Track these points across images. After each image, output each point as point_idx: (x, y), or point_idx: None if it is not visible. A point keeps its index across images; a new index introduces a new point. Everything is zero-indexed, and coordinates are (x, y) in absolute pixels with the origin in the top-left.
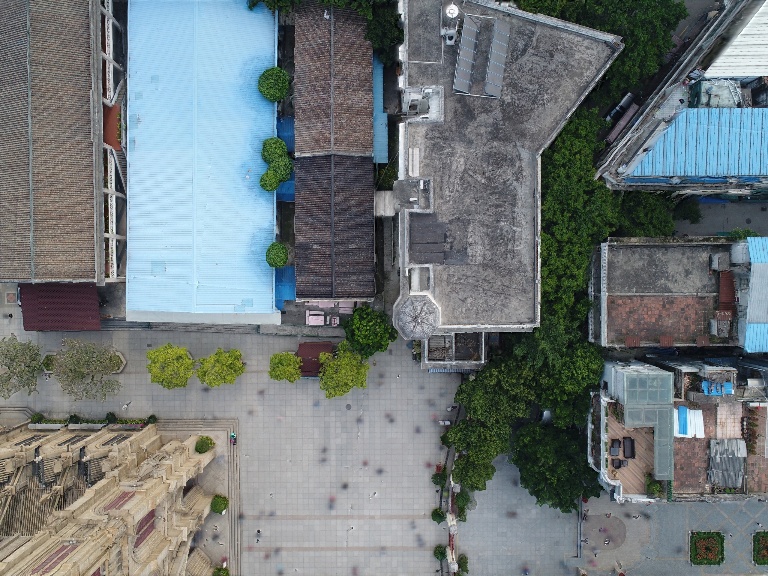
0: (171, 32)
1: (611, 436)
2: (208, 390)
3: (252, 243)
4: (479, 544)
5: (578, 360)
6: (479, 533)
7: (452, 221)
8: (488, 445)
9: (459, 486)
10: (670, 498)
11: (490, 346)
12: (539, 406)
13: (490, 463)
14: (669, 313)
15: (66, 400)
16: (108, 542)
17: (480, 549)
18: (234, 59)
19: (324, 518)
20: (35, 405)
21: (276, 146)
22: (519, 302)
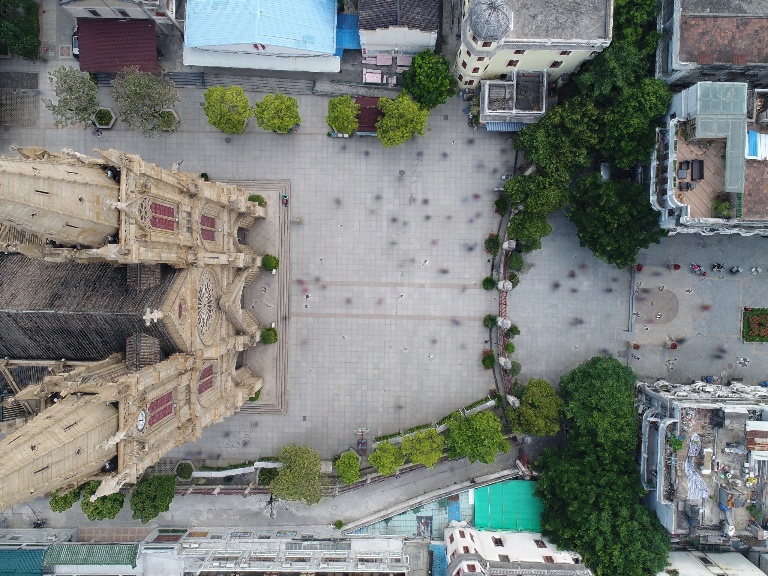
0: None
1: (679, 159)
2: (261, 151)
3: None
4: (529, 315)
5: (647, 87)
6: (530, 304)
7: None
8: (547, 191)
9: (514, 242)
10: (739, 213)
11: (549, 105)
12: (596, 172)
13: (546, 220)
14: (742, 35)
15: None
16: (183, 182)
17: (530, 321)
18: None
19: (374, 285)
20: None
21: None
22: (590, 20)
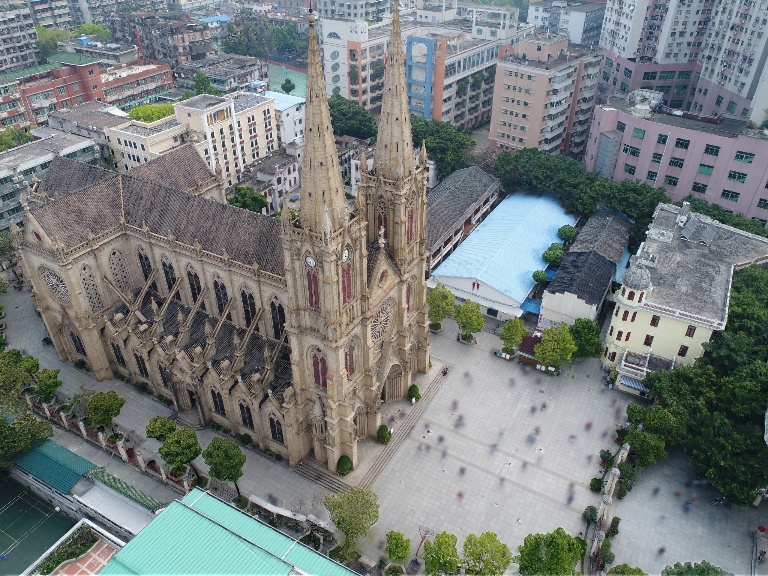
0: (521, 207)
1: None
2: (442, 346)
3: (524, 274)
4: (633, 531)
5: None
6: (635, 521)
7: (667, 274)
8: None
9: (629, 445)
10: None
11: None
12: None
13: None
14: None
15: None
16: None
17: (633, 535)
18: (549, 221)
19: (488, 447)
20: None
21: (560, 244)
22: (710, 315)
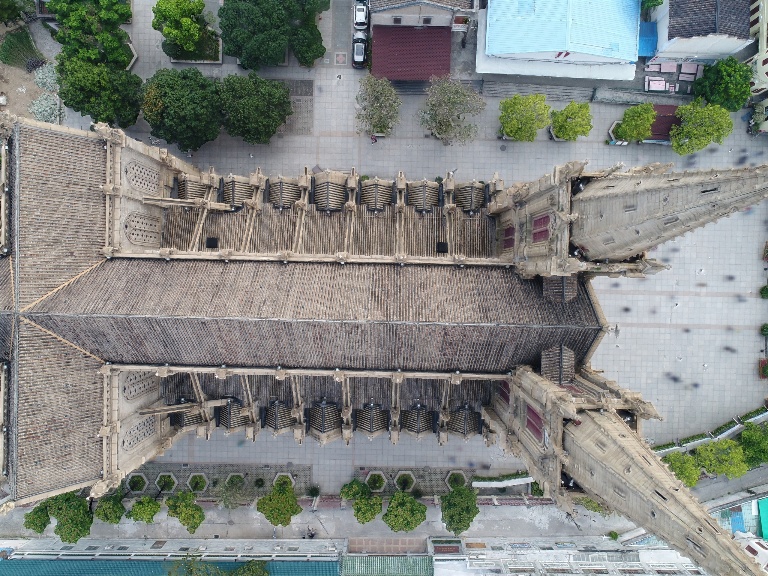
0: None
1: None
2: (536, 159)
3: None
4: None
5: None
6: None
7: None
8: None
9: None
10: None
11: None
12: None
13: None
14: None
15: (391, 165)
16: None
17: None
18: None
19: (648, 294)
20: (360, 169)
21: None
22: None
